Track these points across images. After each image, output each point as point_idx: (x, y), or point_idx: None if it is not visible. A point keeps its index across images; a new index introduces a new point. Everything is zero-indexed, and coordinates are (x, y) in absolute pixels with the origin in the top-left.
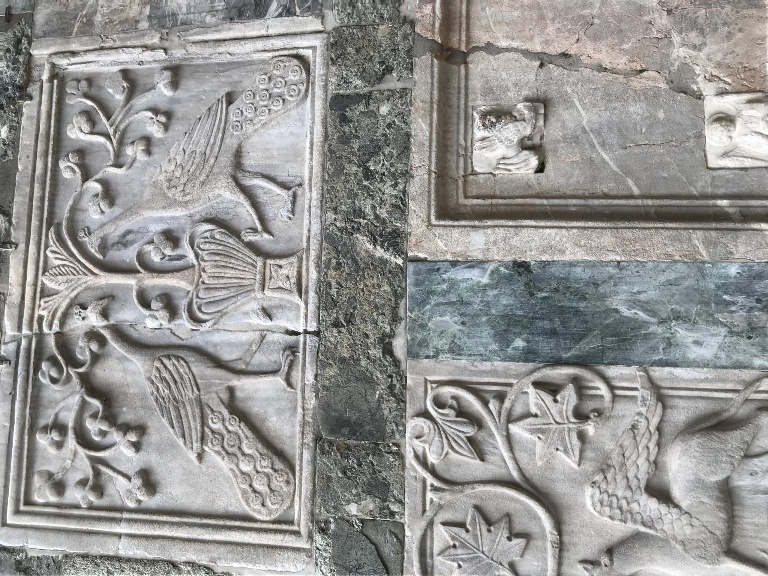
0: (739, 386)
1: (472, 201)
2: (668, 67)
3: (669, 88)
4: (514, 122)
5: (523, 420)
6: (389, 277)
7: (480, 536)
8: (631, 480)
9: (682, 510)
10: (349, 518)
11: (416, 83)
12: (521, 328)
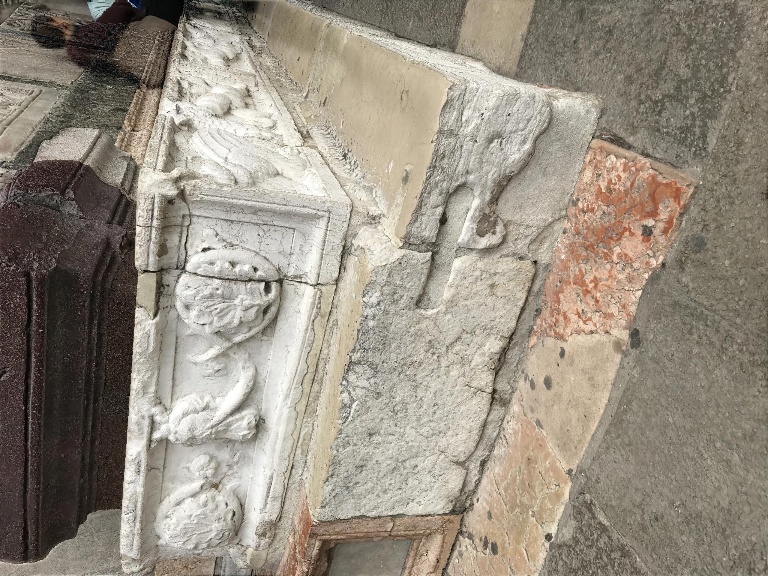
0: None
1: None
2: None
3: None
4: None
5: None
6: None
7: None
8: None
9: None
10: None
11: None
12: None
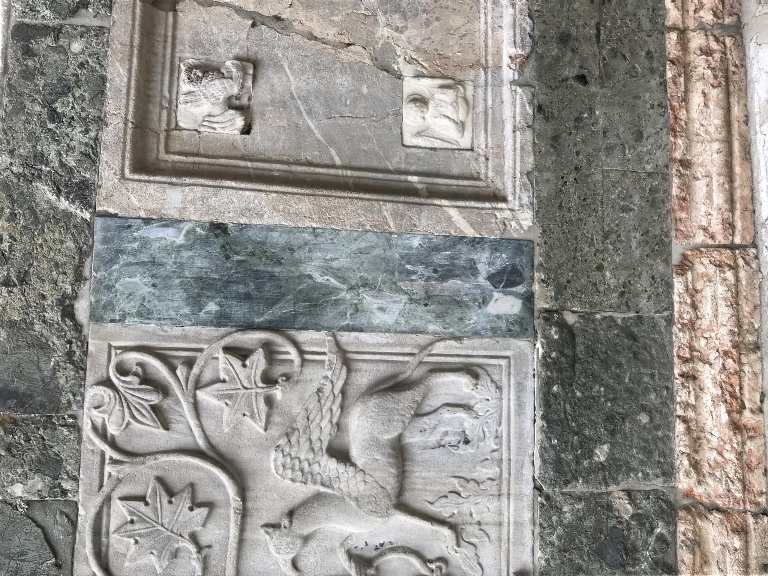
0: (415, 350)
1: (173, 157)
2: (373, 44)
3: (373, 65)
4: (221, 79)
5: (210, 386)
6: (73, 233)
7: (160, 508)
8: (314, 442)
9: (357, 468)
10: (12, 500)
11: (115, 23)
12: (215, 292)
